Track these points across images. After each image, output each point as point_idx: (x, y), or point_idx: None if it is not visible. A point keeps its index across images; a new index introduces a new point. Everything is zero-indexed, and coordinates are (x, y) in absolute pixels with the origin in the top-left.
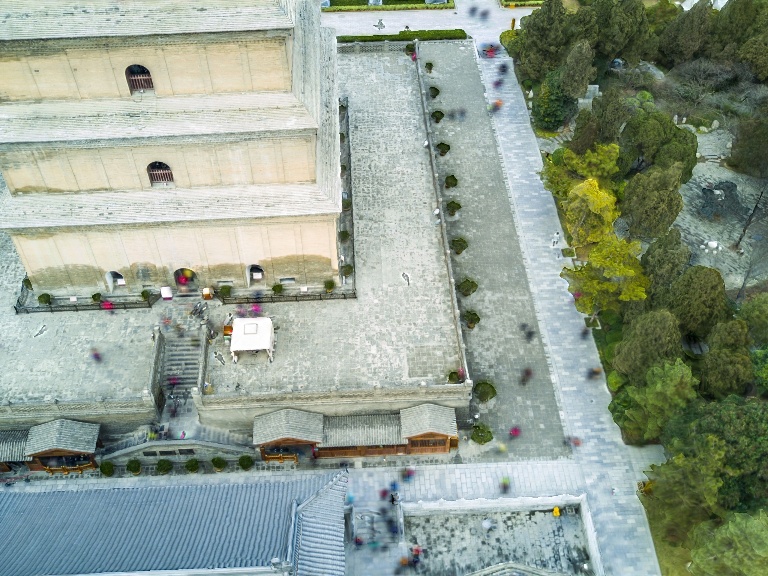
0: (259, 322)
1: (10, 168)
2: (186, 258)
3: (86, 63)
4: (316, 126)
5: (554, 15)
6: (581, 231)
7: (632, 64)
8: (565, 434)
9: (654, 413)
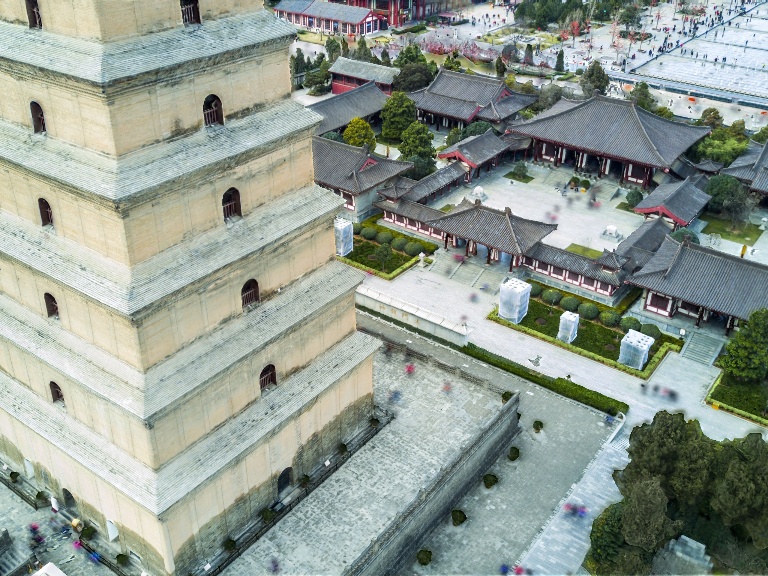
0: None
1: None
2: (68, 481)
3: (24, 277)
4: (142, 416)
5: (654, 433)
6: None
7: (757, 543)
8: None
9: None
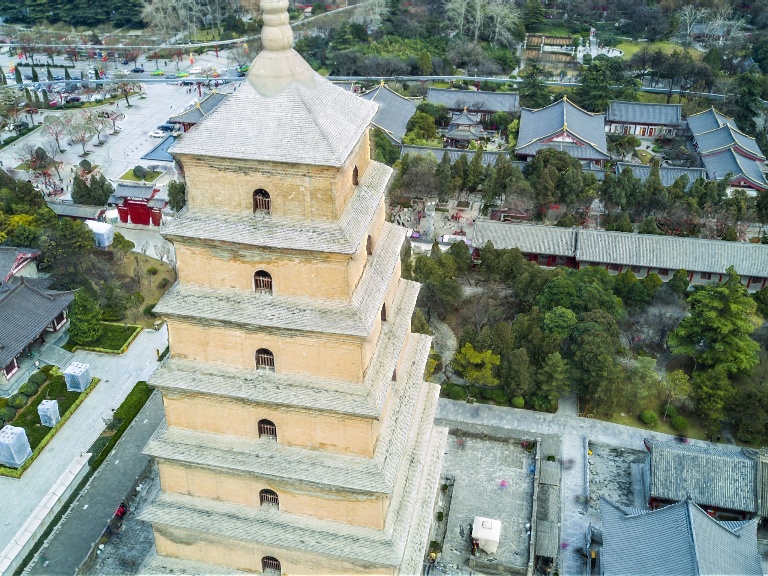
0: (481, 521)
1: (394, 573)
2: None
3: None
4: None
5: None
6: (425, 371)
7: None
8: (546, 433)
9: (562, 383)
